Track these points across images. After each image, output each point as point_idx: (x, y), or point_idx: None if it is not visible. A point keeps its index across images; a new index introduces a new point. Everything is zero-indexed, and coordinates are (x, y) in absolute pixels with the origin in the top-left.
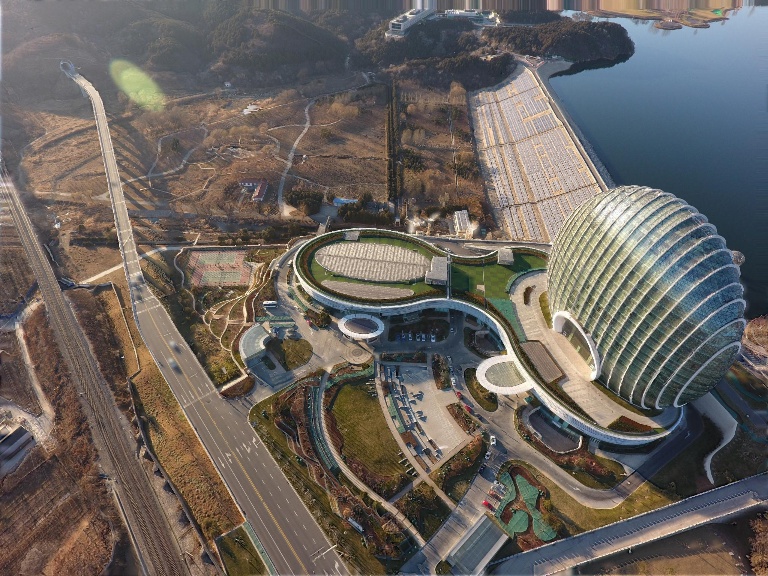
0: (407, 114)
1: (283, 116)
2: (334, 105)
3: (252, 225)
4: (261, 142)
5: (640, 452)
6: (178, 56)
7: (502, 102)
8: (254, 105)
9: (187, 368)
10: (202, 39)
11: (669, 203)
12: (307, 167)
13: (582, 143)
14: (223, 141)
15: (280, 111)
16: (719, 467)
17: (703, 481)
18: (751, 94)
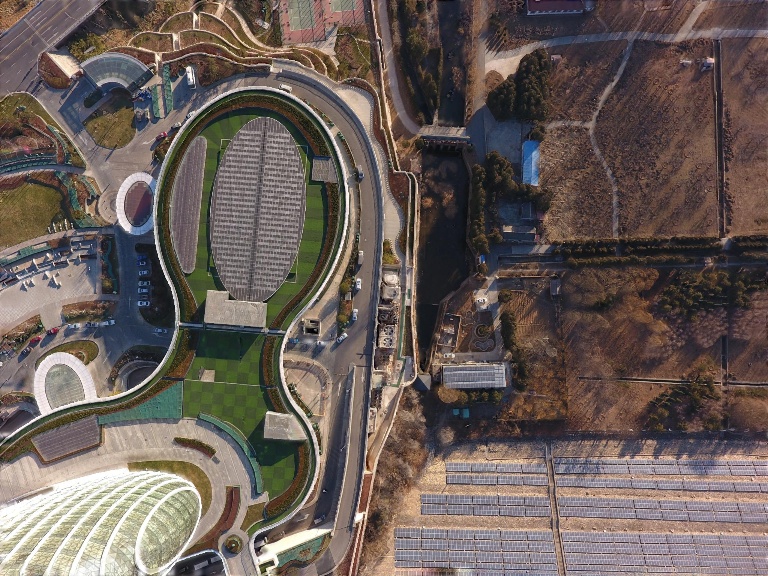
0: None
1: None
2: None
3: (458, 17)
4: None
5: None
6: None
7: None
8: None
9: (78, 4)
10: None
11: None
12: (667, 74)
13: None
14: None
15: None
16: None
17: None
18: None
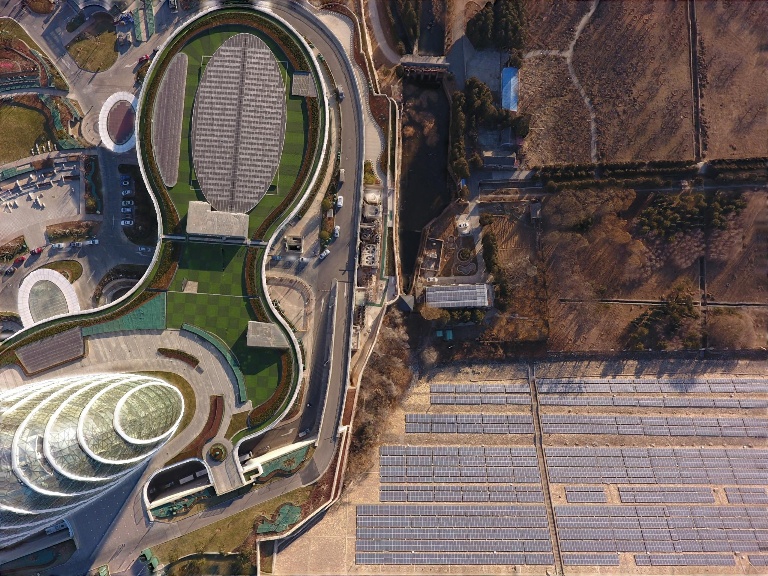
0: None
1: None
2: None
3: None
4: None
5: None
6: None
7: None
8: None
9: None
10: None
11: None
12: (642, 4)
13: None
14: None
15: None
16: None
17: None
18: None
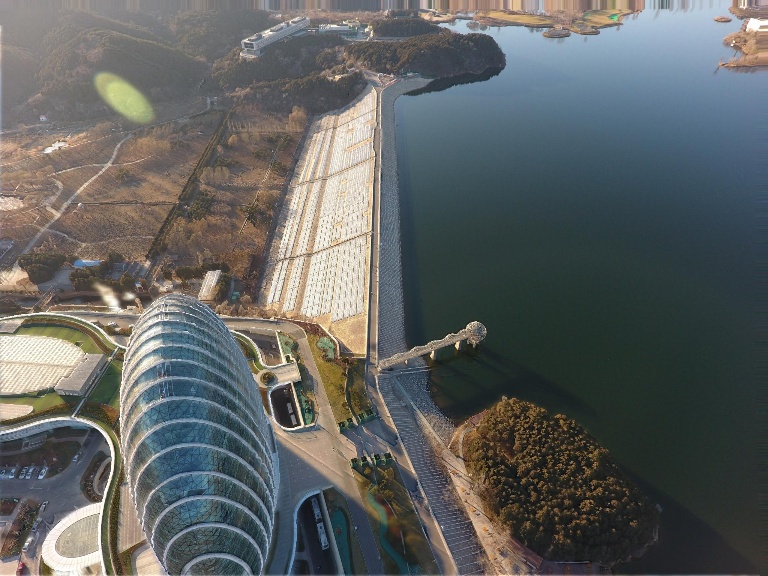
0: (228, 146)
1: (84, 155)
2: (142, 140)
3: None
4: (41, 188)
5: None
6: None
7: (339, 128)
8: (62, 142)
9: None
10: (33, 67)
11: (150, 338)
12: (76, 218)
13: (384, 179)
14: None
15: (82, 149)
16: None
17: None
18: (589, 112)
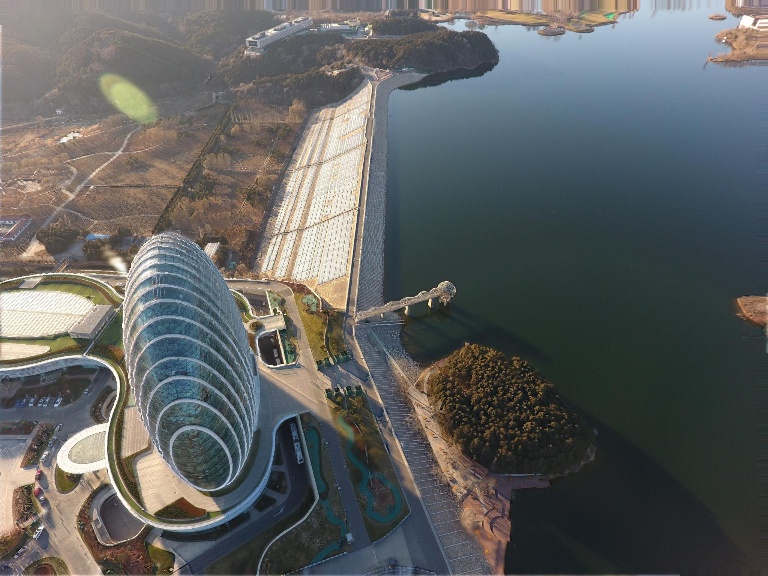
0: (230, 136)
1: (97, 144)
2: (150, 130)
3: None
4: (57, 173)
5: (207, 538)
6: (12, 84)
7: (335, 119)
8: (77, 133)
9: None
10: (50, 65)
11: (147, 258)
12: (88, 199)
13: (374, 162)
14: (15, 174)
15: (95, 138)
16: (274, 557)
17: (249, 575)
18: (571, 102)
